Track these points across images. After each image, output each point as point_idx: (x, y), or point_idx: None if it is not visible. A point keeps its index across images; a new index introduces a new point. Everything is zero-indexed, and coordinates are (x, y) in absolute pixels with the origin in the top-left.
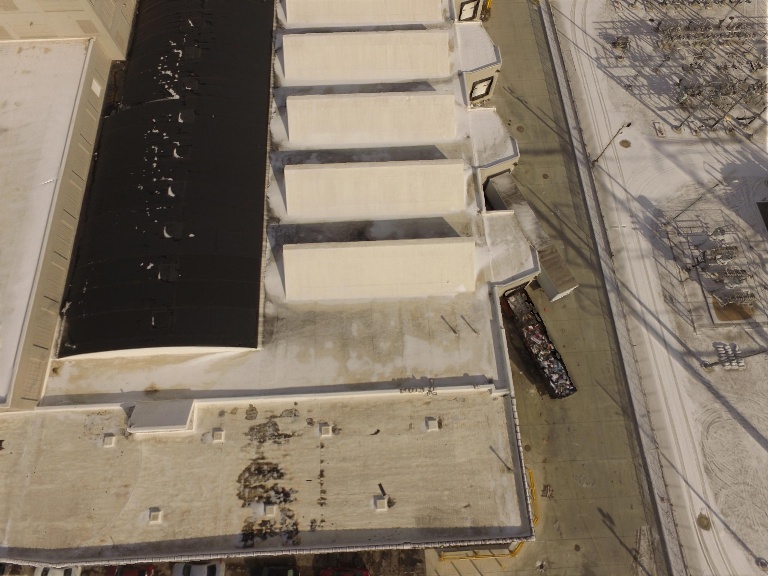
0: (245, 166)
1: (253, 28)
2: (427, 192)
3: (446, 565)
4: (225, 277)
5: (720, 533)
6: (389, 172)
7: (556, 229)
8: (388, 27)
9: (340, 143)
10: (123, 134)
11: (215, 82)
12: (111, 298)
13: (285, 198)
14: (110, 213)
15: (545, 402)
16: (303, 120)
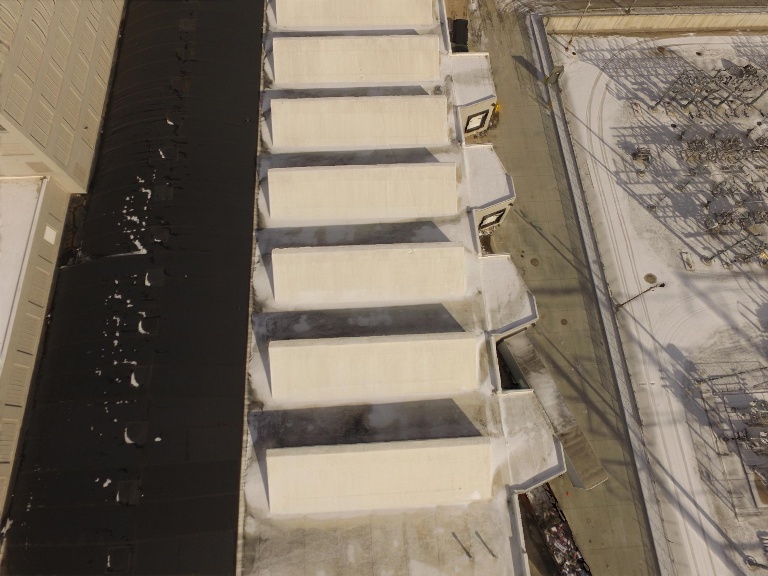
0: (223, 338)
1: (234, 156)
2: (434, 370)
3: None
4: (197, 492)
5: None
6: (390, 348)
7: (577, 389)
8: (387, 151)
9: (333, 302)
10: (80, 296)
11: (189, 231)
12: (59, 525)
13: (269, 379)
14: (62, 404)
15: None
16: (291, 276)
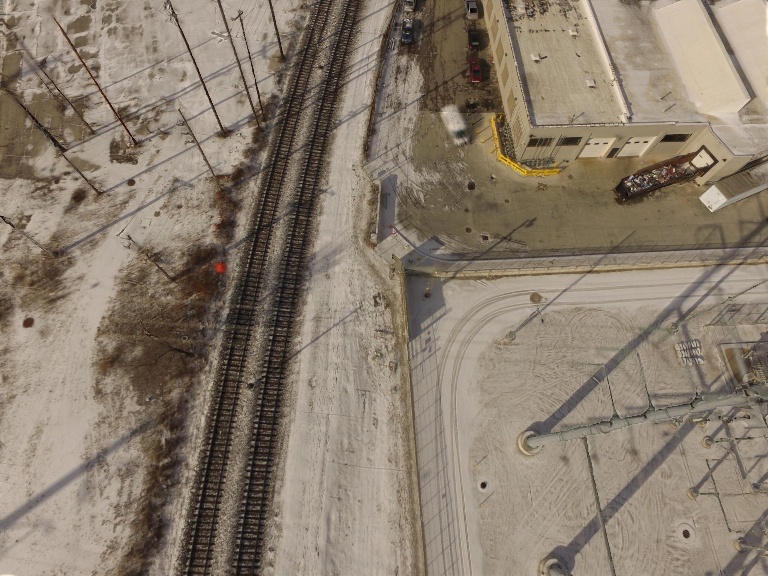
0: None
1: None
2: None
3: (487, 123)
4: None
5: (530, 309)
6: None
7: None
8: None
9: None
10: None
11: None
12: None
13: (733, 3)
14: None
15: (609, 192)
16: None
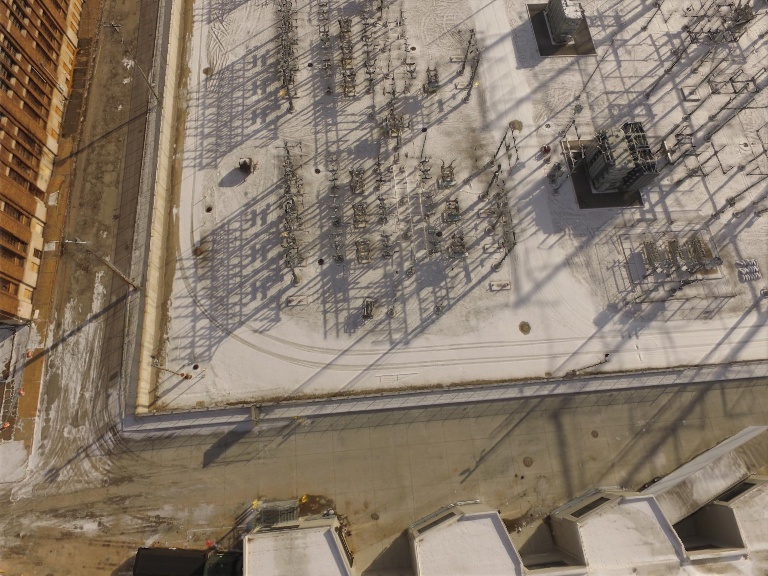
0: None
1: None
2: None
3: None
4: None
5: None
6: None
7: (664, 428)
8: None
9: None
10: None
11: None
12: None
13: None
14: None
15: None
16: None
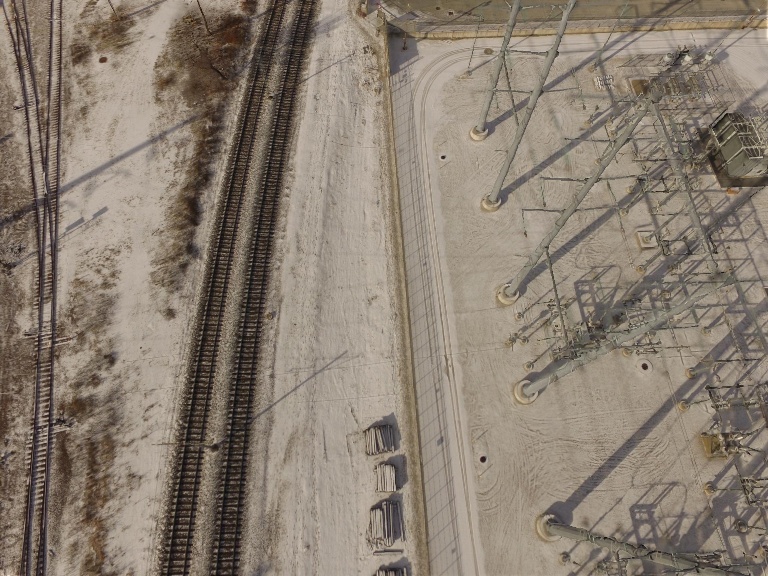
0: None
1: None
2: None
3: None
4: None
5: (483, 58)
6: None
7: (678, 0)
8: None
9: None
10: None
11: None
12: None
13: None
14: None
15: None
16: None
